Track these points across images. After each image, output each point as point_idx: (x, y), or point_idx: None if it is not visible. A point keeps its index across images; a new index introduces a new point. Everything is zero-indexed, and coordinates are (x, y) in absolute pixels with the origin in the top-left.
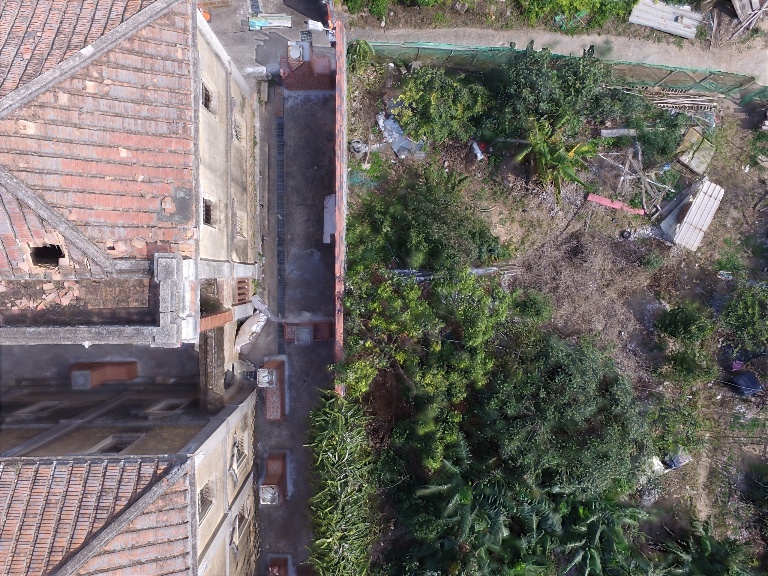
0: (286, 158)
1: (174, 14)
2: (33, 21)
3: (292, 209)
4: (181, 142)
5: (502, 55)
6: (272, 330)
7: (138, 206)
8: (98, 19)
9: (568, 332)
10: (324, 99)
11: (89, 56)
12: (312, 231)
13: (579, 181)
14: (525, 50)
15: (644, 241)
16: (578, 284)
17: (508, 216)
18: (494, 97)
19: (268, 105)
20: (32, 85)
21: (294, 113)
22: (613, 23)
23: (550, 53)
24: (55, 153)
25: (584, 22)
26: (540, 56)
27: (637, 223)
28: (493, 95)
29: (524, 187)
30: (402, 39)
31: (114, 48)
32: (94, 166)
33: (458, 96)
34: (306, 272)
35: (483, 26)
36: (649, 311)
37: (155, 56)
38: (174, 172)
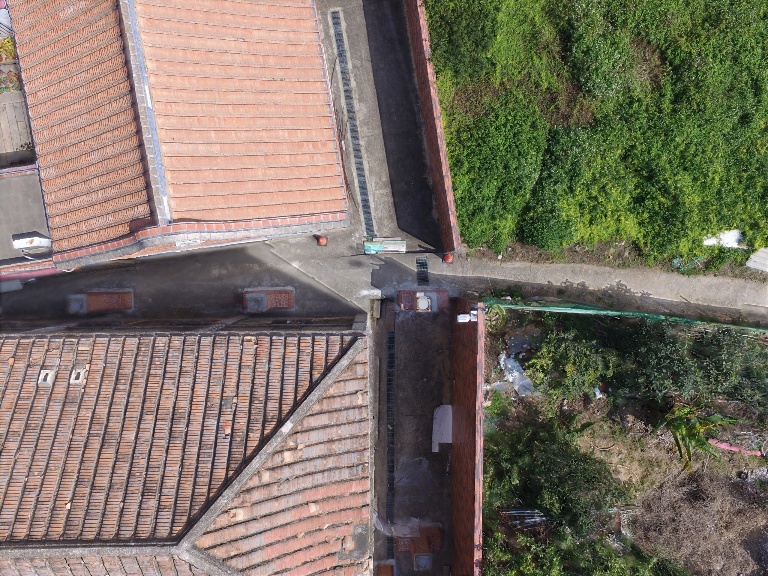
0: (396, 371)
1: (354, 362)
2: (227, 383)
3: (402, 419)
4: (360, 483)
5: (631, 318)
6: (381, 536)
7: (323, 552)
8: (288, 379)
9: (688, 575)
10: (434, 314)
11: (288, 431)
12: (421, 440)
13: (711, 453)
14: (659, 325)
15: (762, 484)
16: (696, 525)
17: (627, 455)
18: (622, 356)
19: (380, 320)
20: (243, 477)
21: (405, 328)
22: (730, 266)
23: (687, 337)
24: (259, 530)
25: (701, 264)
26: (680, 345)
27: (754, 465)
28: (621, 354)
29: (643, 427)
30: (518, 271)
31: (306, 413)
32: (289, 529)
33: (590, 361)
34: (415, 480)
35: (600, 264)
36: (766, 552)
37: (339, 407)
38: (354, 513)
